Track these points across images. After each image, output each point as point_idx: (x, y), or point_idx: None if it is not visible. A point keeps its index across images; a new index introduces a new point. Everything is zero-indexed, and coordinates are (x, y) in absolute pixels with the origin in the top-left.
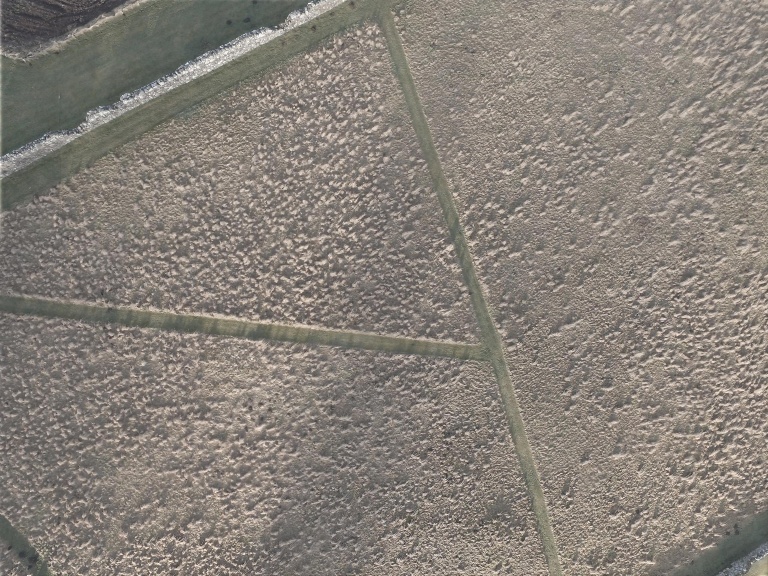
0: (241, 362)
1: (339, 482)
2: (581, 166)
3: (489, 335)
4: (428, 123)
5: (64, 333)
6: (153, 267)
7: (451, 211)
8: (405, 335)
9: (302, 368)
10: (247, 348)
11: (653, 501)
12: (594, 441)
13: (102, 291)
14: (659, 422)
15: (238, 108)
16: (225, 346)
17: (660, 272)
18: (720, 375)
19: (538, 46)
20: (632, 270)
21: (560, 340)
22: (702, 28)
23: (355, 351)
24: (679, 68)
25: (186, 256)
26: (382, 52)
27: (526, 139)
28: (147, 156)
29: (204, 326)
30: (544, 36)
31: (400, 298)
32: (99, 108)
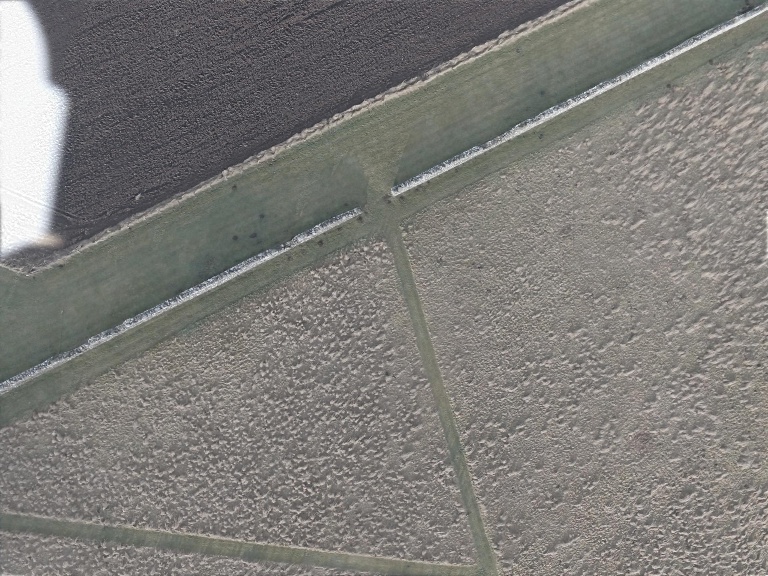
0: None
1: None
2: (584, 383)
3: (485, 555)
4: (432, 340)
5: (59, 551)
6: (150, 485)
7: (452, 430)
8: (401, 557)
9: None
10: (242, 569)
11: None
12: None
13: (99, 508)
14: None
15: (241, 325)
16: (220, 567)
17: (659, 488)
18: None
19: (546, 261)
20: (631, 487)
21: (556, 558)
22: (712, 242)
23: (350, 573)
24: (687, 282)
25: (184, 475)
26: (388, 268)
27: (530, 356)
28: (148, 374)
29: (200, 545)
30: (552, 251)
31: (397, 520)
32: (101, 334)
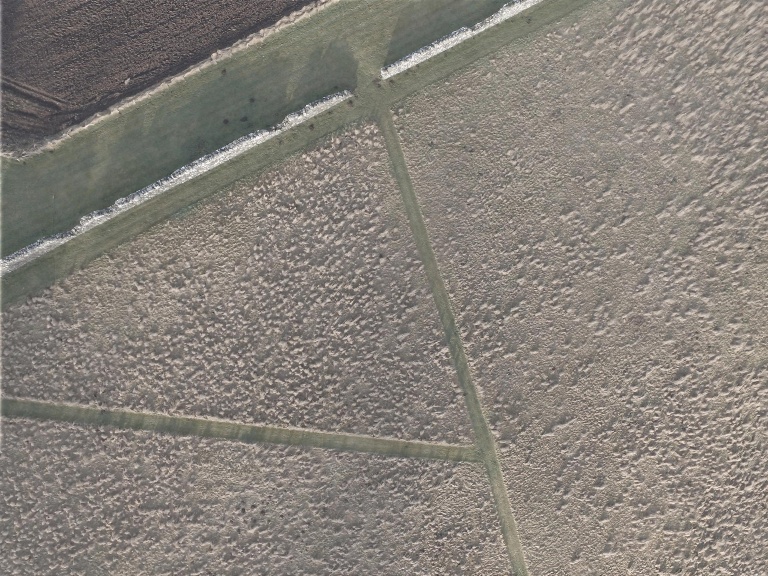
0: (234, 465)
1: None
2: (577, 266)
3: (483, 436)
4: (425, 223)
5: (57, 435)
6: (147, 369)
7: (447, 312)
8: (399, 438)
9: (295, 470)
10: (240, 451)
11: None
12: (585, 539)
13: (95, 393)
14: (650, 520)
15: (234, 208)
16: (218, 449)
17: (654, 371)
18: (711, 472)
19: (537, 145)
20: (626, 369)
21: (553, 439)
22: (701, 126)
23: (349, 453)
24: (677, 166)
25: (180, 358)
26: (380, 151)
27: (523, 239)
28: (142, 257)
29: (198, 428)
30: (543, 134)
31: (394, 401)
32: (94, 213)
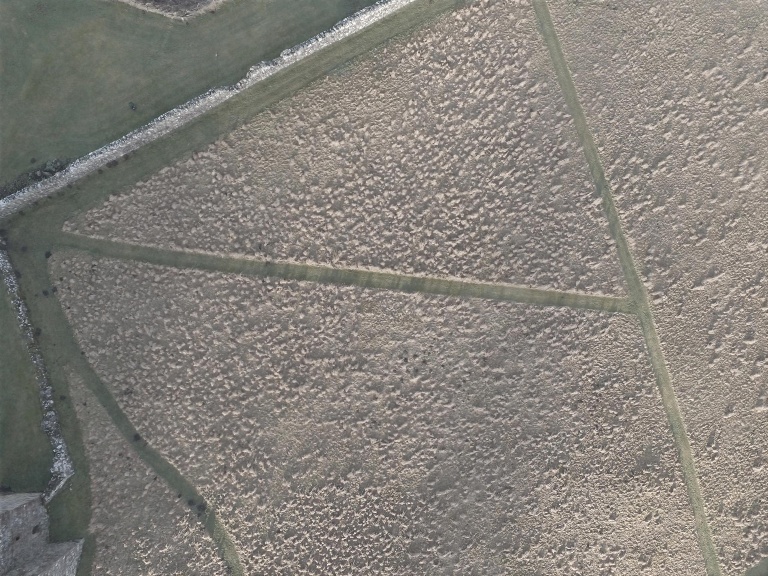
0: (396, 314)
1: (492, 433)
2: (722, 121)
3: (635, 288)
4: (573, 79)
5: (224, 286)
6: (309, 221)
7: (596, 166)
8: (555, 288)
9: (455, 321)
10: (402, 301)
11: None
12: (737, 394)
13: (260, 245)
14: None
15: (389, 65)
16: (380, 299)
17: None
18: None
19: (678, 2)
20: None
21: (703, 294)
22: None
23: (507, 304)
24: None
25: (341, 210)
26: (527, 9)
27: (667, 94)
28: (302, 112)
29: (359, 279)
30: None
31: (550, 251)
32: (262, 63)
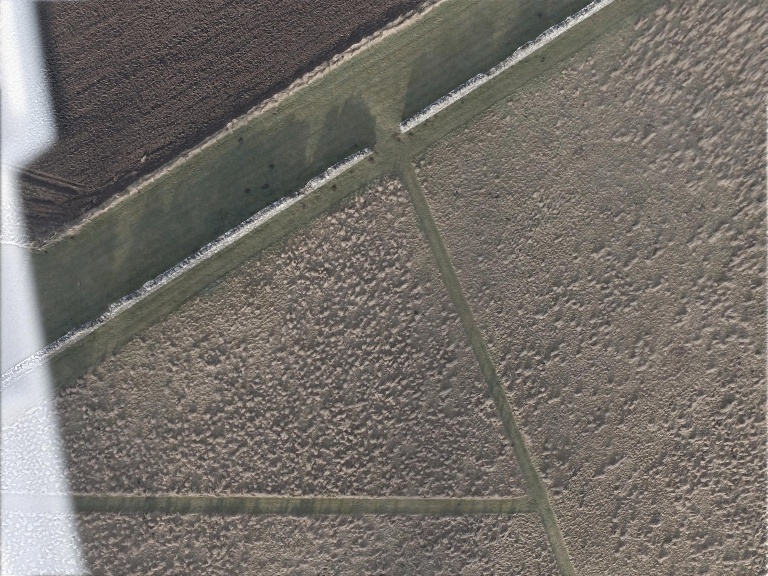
0: (286, 540)
1: None
2: (614, 303)
3: (534, 485)
4: (457, 274)
5: (103, 528)
6: (189, 450)
7: (487, 362)
8: (450, 496)
9: (349, 539)
10: (291, 525)
11: None
12: None
13: (138, 480)
14: (708, 552)
15: (263, 278)
16: (269, 525)
17: (699, 401)
18: (765, 498)
19: (562, 184)
20: (671, 402)
21: (605, 481)
22: (724, 149)
23: (401, 517)
24: (704, 192)
25: (222, 436)
26: (405, 206)
27: (557, 280)
28: (174, 337)
29: (246, 506)
30: (567, 173)
31: (443, 459)
32: (123, 299)
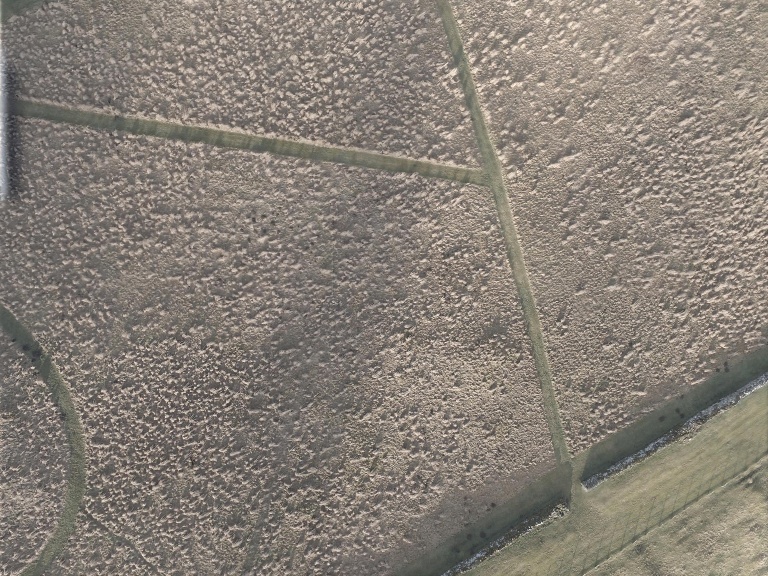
0: (245, 174)
1: (339, 296)
2: (584, 2)
3: (490, 161)
4: None
5: (71, 138)
6: (160, 78)
7: (455, 38)
8: (407, 155)
9: (305, 183)
10: (251, 161)
11: (646, 335)
12: (590, 272)
13: (109, 99)
14: (654, 258)
15: None
16: (230, 158)
17: (659, 111)
18: (714, 216)
19: None
20: (631, 108)
21: (559, 172)
22: None
23: (358, 169)
24: None
25: (193, 68)
26: None
27: None
28: None
29: (209, 138)
30: None
31: (403, 118)
32: None
